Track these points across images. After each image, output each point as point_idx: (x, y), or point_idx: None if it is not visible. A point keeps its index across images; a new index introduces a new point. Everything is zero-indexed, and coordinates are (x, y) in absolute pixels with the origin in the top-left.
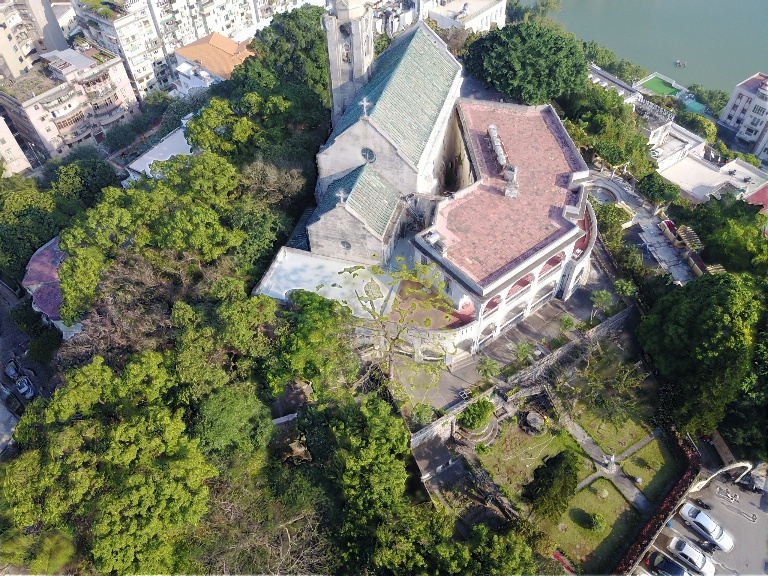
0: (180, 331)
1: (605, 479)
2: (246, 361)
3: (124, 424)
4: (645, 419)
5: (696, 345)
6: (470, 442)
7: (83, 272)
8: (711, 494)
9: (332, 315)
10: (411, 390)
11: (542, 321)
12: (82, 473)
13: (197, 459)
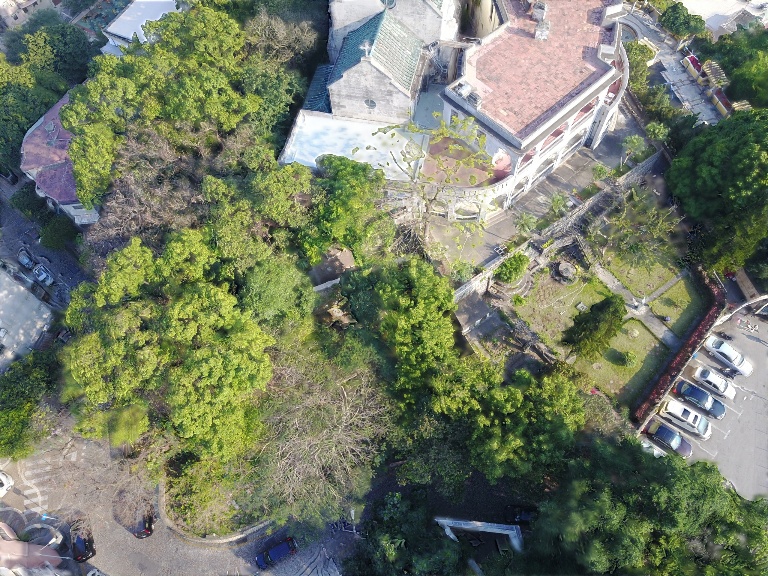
0: (215, 206)
1: (635, 320)
2: (282, 232)
3: (180, 302)
4: (672, 261)
5: (729, 185)
6: (506, 295)
7: (96, 151)
8: (733, 326)
9: (367, 179)
10: (458, 249)
11: (572, 171)
12: (149, 351)
13: (255, 330)
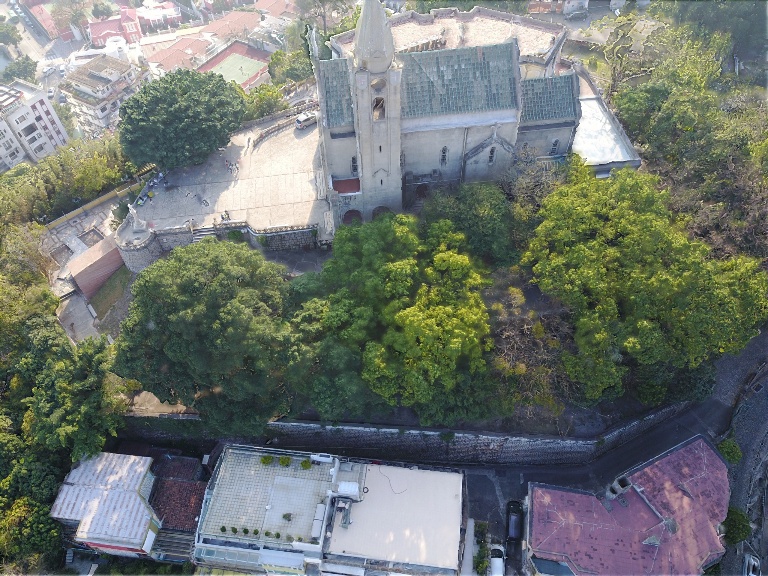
0: None
1: None
2: None
3: None
4: None
5: (492, 6)
6: None
7: None
8: None
9: None
10: None
11: None
12: None
13: None
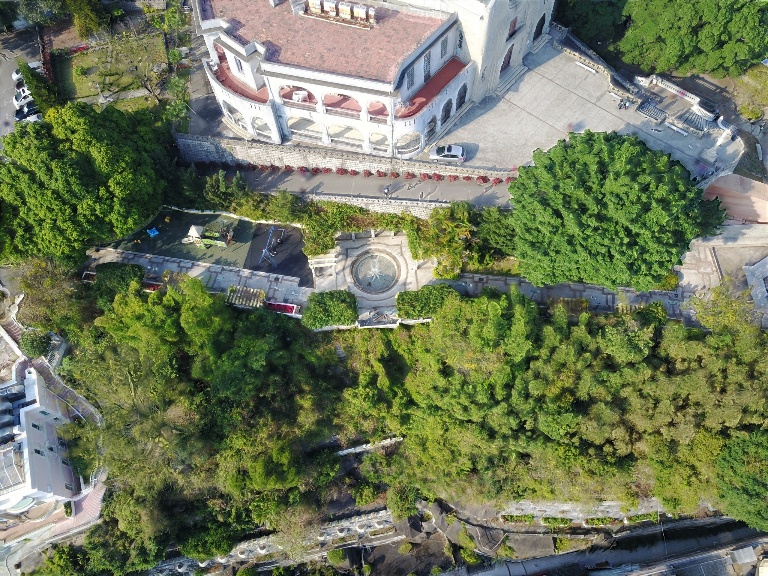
0: None
1: None
2: None
3: None
4: None
5: None
6: None
7: None
8: None
9: None
10: None
11: None
12: None
13: None
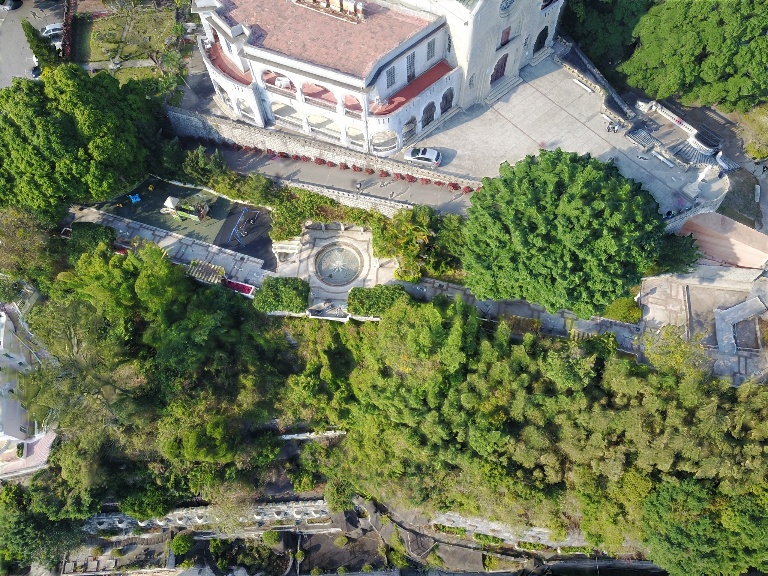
0: None
1: None
2: None
3: None
4: None
5: None
6: None
7: None
8: None
9: None
10: None
11: None
12: None
13: None
